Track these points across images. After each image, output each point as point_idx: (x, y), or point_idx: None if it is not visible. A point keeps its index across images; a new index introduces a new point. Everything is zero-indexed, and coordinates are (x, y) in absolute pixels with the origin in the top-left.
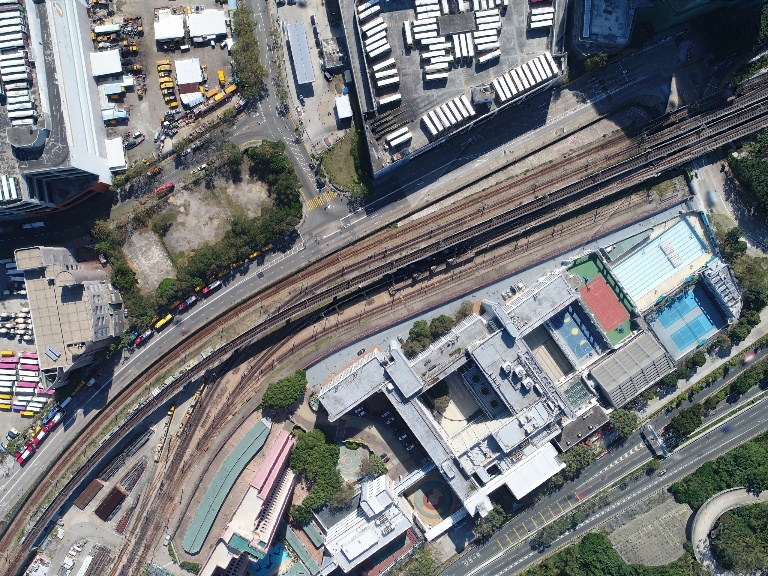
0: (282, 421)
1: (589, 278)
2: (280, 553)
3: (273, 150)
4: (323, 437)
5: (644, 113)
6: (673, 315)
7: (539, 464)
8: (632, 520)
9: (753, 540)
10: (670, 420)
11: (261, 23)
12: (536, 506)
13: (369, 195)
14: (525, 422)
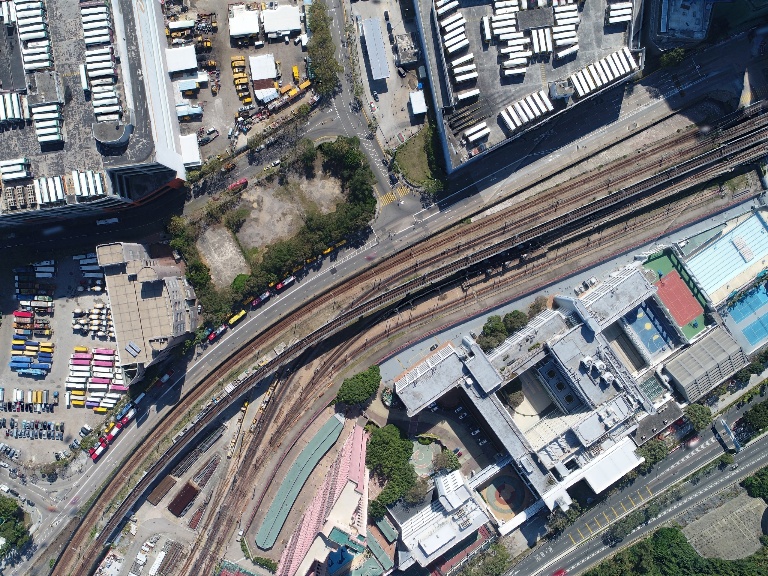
0: (355, 416)
1: (663, 273)
2: None
3: (349, 146)
4: (398, 432)
5: (717, 108)
6: (745, 310)
7: (618, 458)
8: (705, 514)
9: None
10: (741, 415)
11: (335, 19)
12: (608, 501)
13: (443, 191)
14: (606, 416)
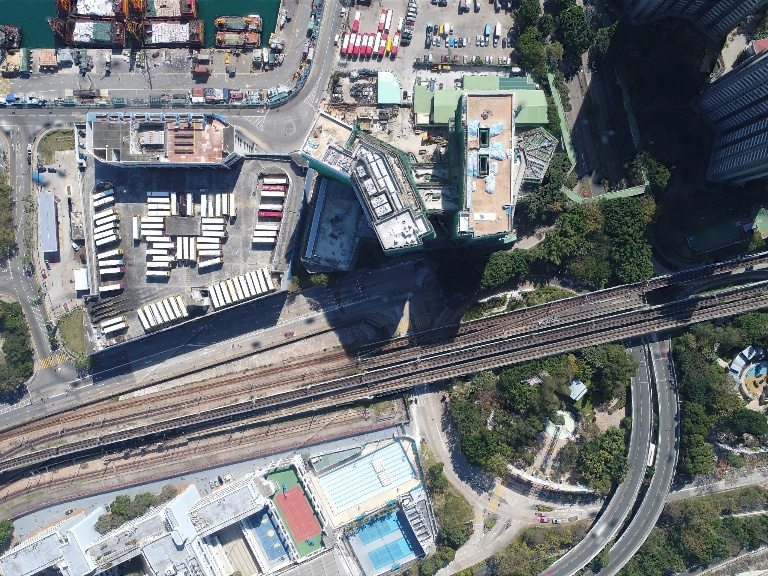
0: None
1: (287, 487)
2: None
3: (5, 312)
4: None
5: (372, 332)
6: (373, 533)
7: None
8: None
9: None
10: None
11: (22, 185)
12: None
13: None
14: None
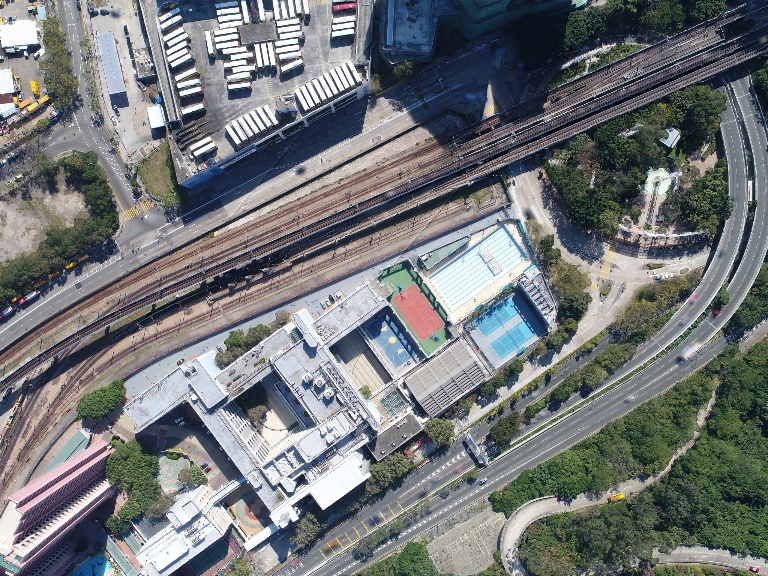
0: (102, 431)
1: (403, 287)
2: (103, 564)
3: (83, 160)
4: (139, 447)
5: (459, 121)
6: (493, 323)
7: (344, 474)
8: (451, 529)
9: (558, 549)
10: None
11: (75, 33)
12: (358, 515)
13: (185, 205)
14: (325, 432)
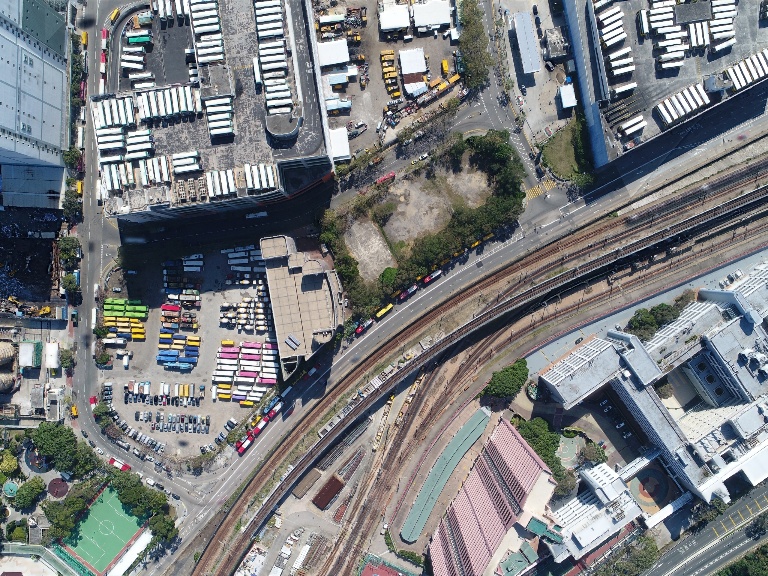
0: (500, 410)
1: None
2: None
3: (501, 139)
4: (546, 425)
5: None
6: None
7: None
8: None
9: None
10: None
11: None
12: (751, 493)
13: (590, 184)
14: (766, 408)
